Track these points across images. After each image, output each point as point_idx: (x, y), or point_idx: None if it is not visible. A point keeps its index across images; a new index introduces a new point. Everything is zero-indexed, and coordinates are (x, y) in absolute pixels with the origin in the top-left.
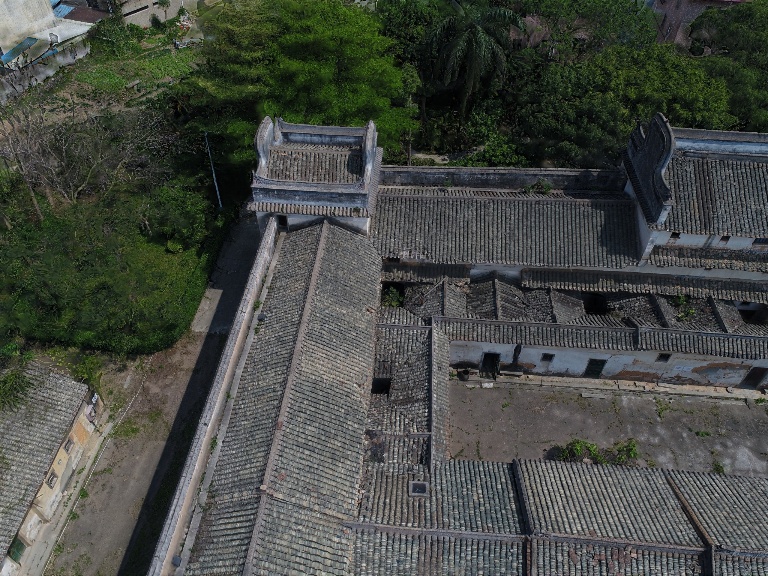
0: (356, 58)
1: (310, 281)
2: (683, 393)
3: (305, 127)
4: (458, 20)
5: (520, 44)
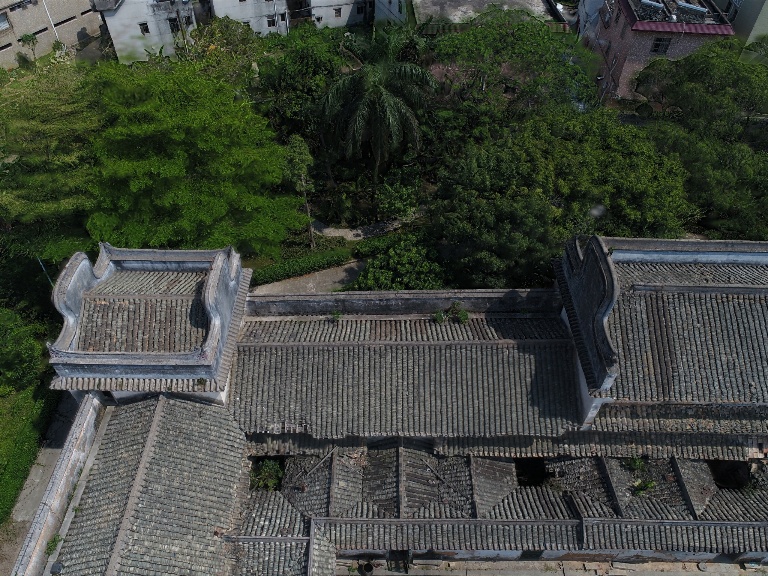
0: (211, 152)
1: (125, 510)
2: (644, 575)
3: (142, 252)
4: (355, 80)
5: (443, 87)
